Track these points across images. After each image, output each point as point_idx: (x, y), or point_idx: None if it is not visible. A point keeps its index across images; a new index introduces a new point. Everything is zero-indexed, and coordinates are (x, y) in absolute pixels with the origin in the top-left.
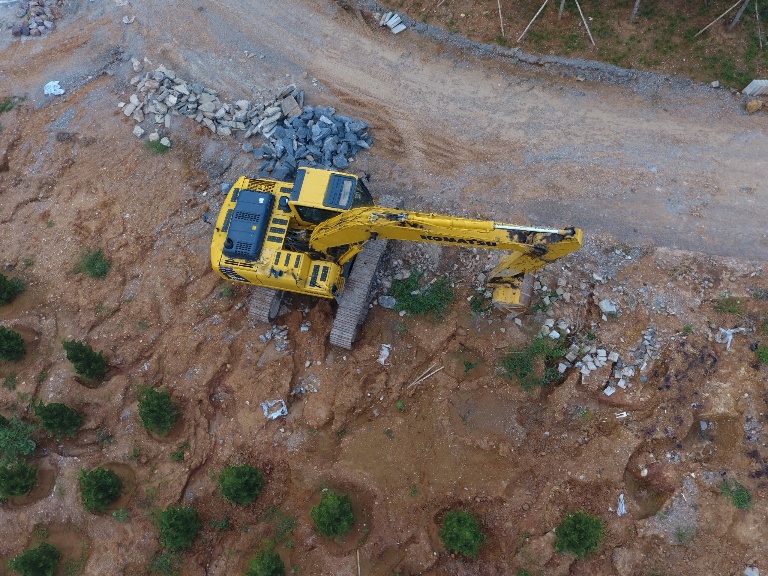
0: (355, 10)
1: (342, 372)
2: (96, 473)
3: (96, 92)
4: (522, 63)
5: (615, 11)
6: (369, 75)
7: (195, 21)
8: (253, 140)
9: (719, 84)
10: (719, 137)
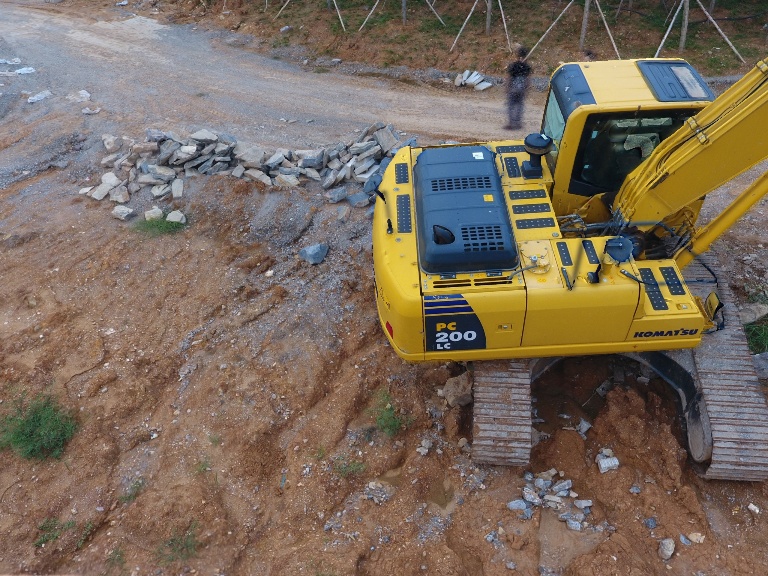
0: (414, 80)
1: None
2: None
3: (36, 186)
4: None
5: (738, 41)
6: (474, 120)
7: (195, 103)
8: None
9: None
10: None
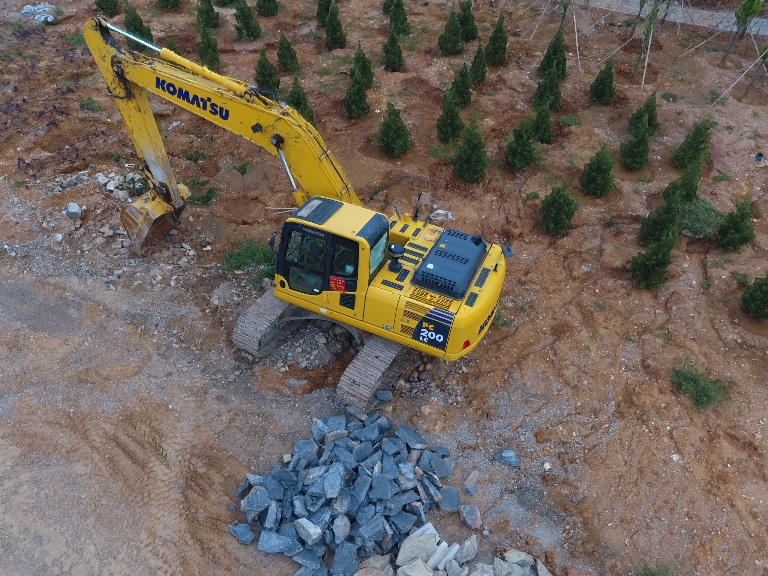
0: None
1: None
2: (598, 158)
3: None
4: None
5: None
6: None
7: None
8: (462, 540)
9: None
10: None
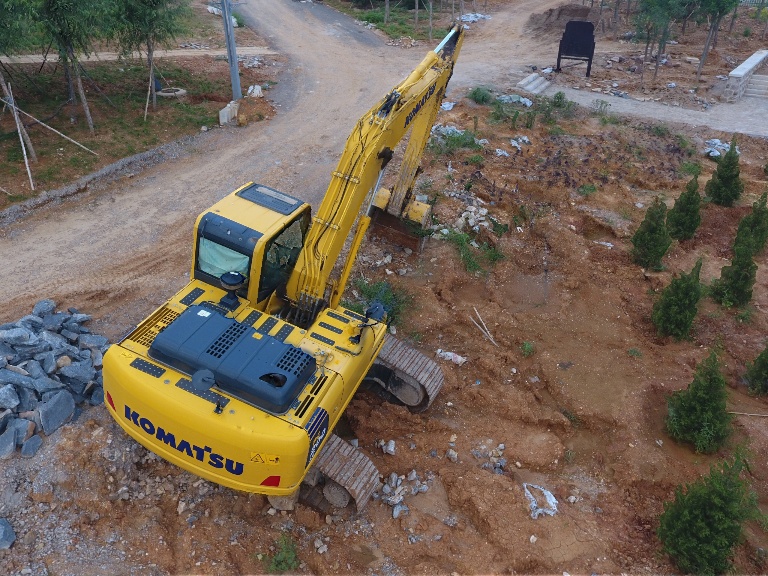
0: None
1: (474, 407)
2: None
3: None
4: (67, 198)
5: None
6: None
7: None
8: None
9: (206, 127)
10: (262, 138)
